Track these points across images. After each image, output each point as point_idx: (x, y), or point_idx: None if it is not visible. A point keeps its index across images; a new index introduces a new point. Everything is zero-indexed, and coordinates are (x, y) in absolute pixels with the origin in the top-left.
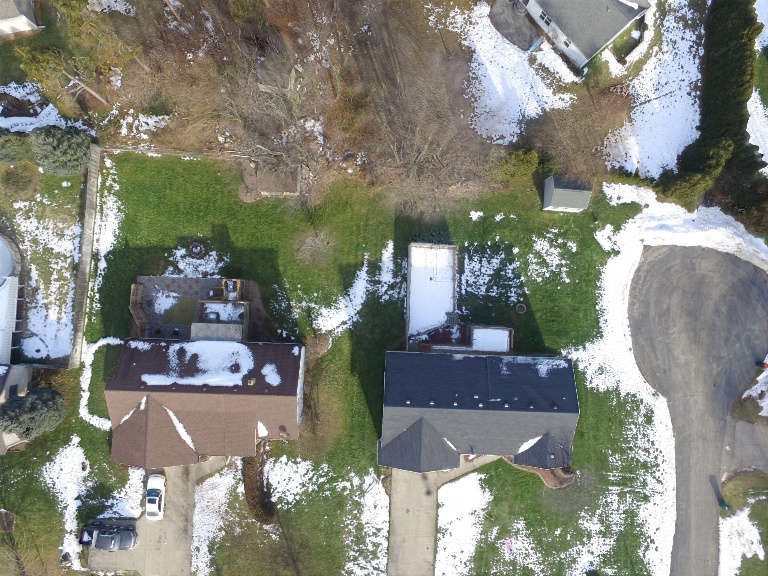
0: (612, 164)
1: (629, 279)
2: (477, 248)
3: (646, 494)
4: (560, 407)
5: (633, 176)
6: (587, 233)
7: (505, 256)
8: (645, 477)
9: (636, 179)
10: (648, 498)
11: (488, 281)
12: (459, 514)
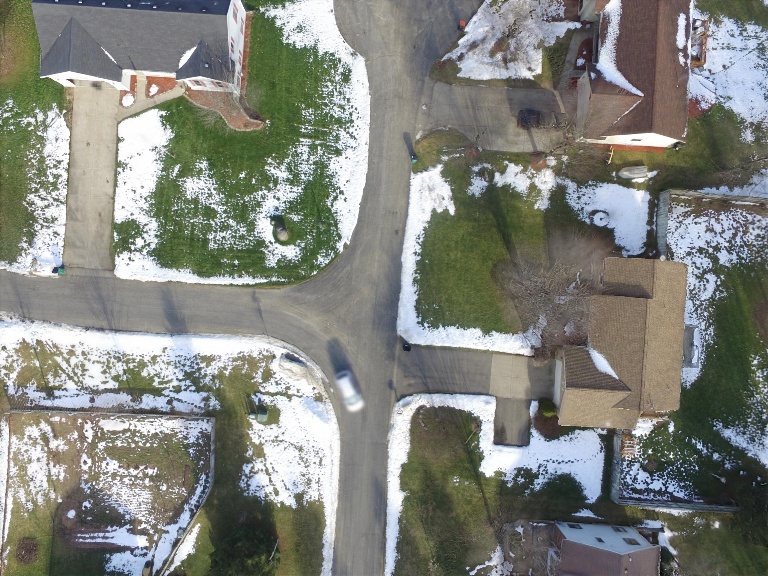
0: None
1: None
2: None
3: (338, 147)
4: (209, 10)
5: None
6: None
7: None
8: (338, 132)
9: None
10: (340, 152)
11: None
12: (139, 149)
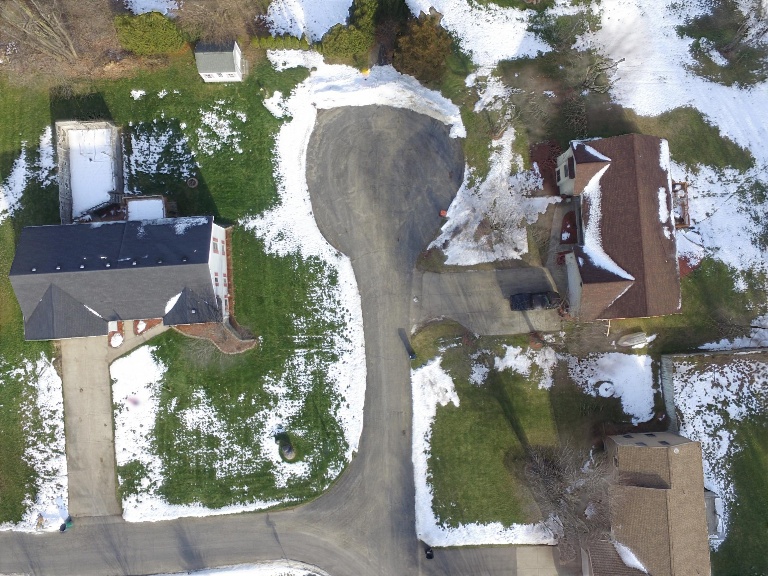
0: (276, 31)
1: (305, 144)
2: (143, 127)
3: (334, 353)
4: (189, 259)
5: (290, 38)
6: (255, 102)
7: (173, 133)
8: (332, 337)
9: (293, 41)
10: (337, 357)
11: (158, 159)
12: (134, 388)
